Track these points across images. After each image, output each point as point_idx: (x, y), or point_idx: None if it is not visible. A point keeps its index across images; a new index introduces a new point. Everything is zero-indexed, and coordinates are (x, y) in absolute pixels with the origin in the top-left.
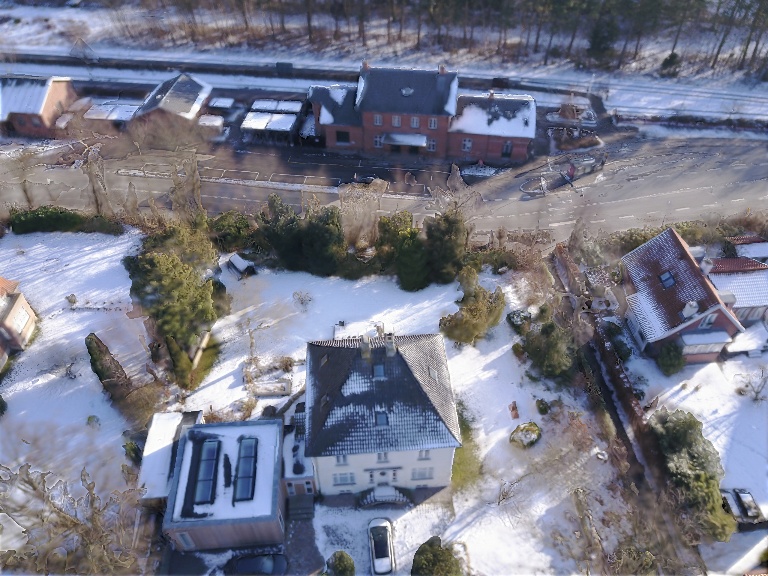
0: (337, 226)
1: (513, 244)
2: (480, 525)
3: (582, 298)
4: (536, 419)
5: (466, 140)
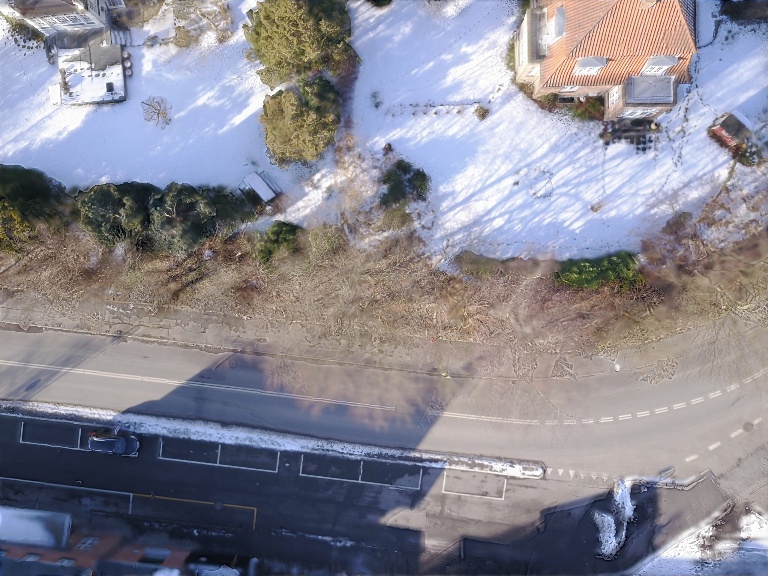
0: None
1: None
2: None
3: None
4: None
5: None
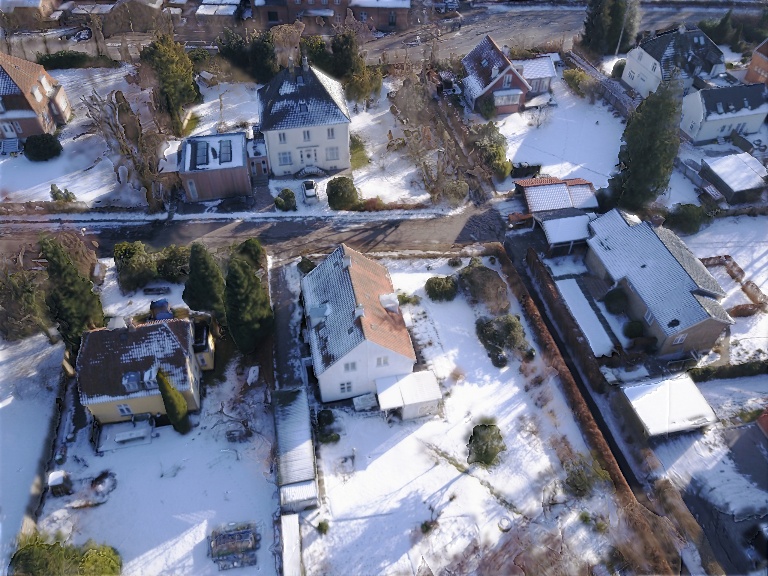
0: (272, 45)
1: None
2: (368, 181)
3: (425, 61)
4: (404, 139)
5: (363, 13)
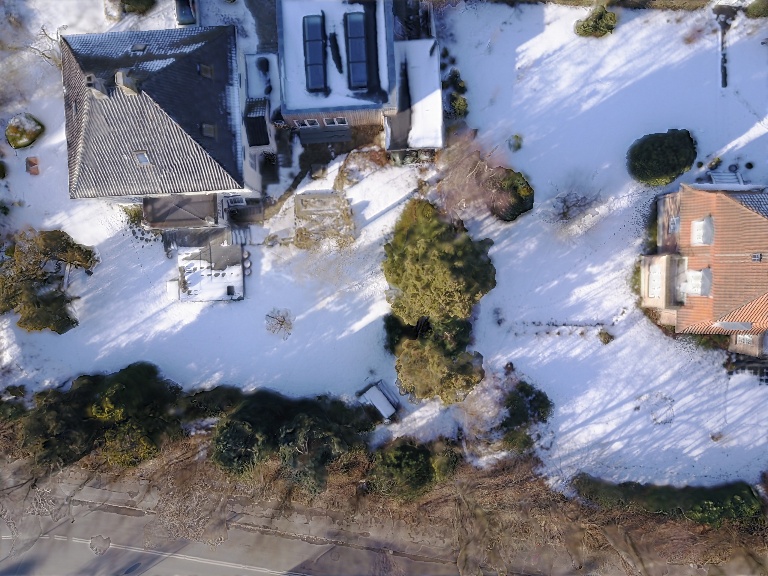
0: None
1: None
2: None
3: None
4: (10, 156)
5: None
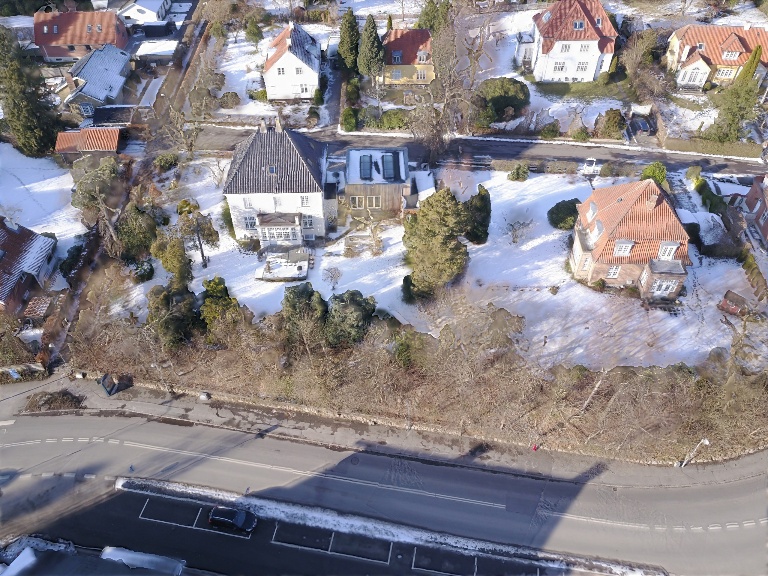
0: None
1: (81, 392)
2: None
3: None
4: (174, 218)
5: None
